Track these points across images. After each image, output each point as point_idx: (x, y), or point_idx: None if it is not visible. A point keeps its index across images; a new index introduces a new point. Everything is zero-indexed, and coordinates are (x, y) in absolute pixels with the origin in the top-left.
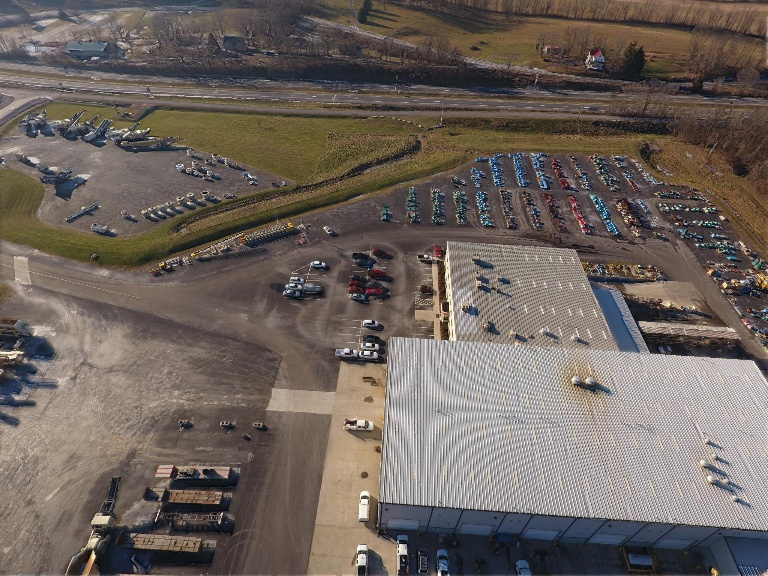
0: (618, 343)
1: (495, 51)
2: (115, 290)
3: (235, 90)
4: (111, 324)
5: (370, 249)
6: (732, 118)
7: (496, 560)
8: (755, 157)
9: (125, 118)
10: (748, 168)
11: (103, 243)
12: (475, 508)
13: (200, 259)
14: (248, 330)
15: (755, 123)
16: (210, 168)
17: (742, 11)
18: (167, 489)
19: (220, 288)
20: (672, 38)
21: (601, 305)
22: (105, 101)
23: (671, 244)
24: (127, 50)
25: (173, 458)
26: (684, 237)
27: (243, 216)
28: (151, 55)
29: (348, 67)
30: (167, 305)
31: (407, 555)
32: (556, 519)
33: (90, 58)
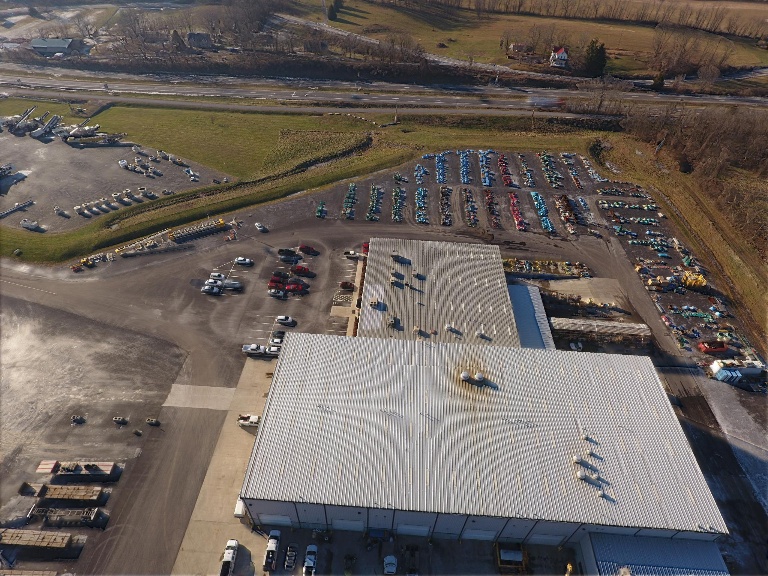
0: (525, 339)
1: (462, 48)
2: (32, 286)
3: (195, 87)
4: (22, 320)
5: (298, 245)
6: (685, 115)
7: (366, 556)
8: (701, 154)
9: (78, 114)
10: (693, 165)
11: (30, 239)
12: (335, 503)
13: (124, 255)
14: (159, 326)
15: (704, 120)
16: (154, 164)
17: (712, 9)
18: (46, 484)
19: (139, 284)
20: (639, 35)
21: (515, 301)
22: (61, 97)
23: (604, 241)
24: (93, 47)
25: (59, 453)
26: (618, 234)
27: (176, 212)
28: (114, 52)
29: (310, 64)
30: (82, 301)
31: (275, 550)
32: (419, 514)
33: (53, 55)
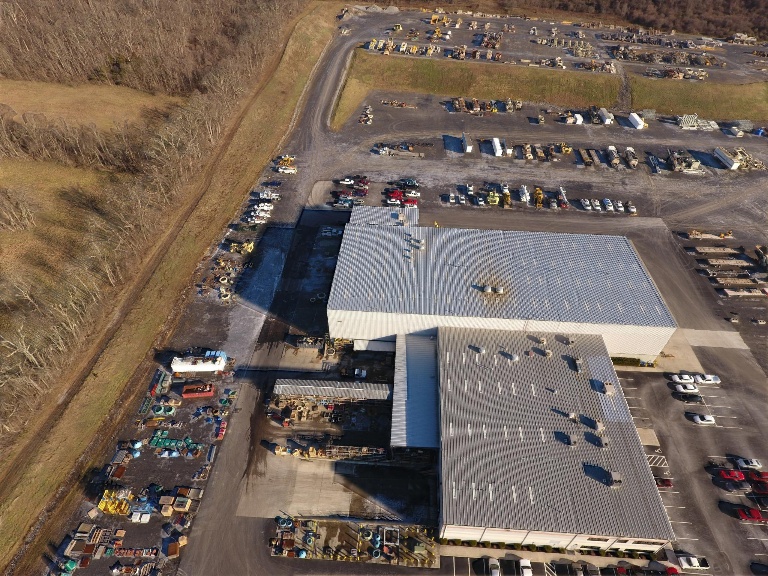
0: (427, 365)
1: None
2: None
3: None
4: None
5: None
6: None
7: None
8: None
9: None
10: None
11: None
12: None
13: None
14: None
15: None
16: None
17: None
18: None
19: None
20: None
21: (428, 417)
22: None
23: None
24: None
25: None
26: None
27: None
28: None
29: None
30: None
31: None
32: None
33: None
